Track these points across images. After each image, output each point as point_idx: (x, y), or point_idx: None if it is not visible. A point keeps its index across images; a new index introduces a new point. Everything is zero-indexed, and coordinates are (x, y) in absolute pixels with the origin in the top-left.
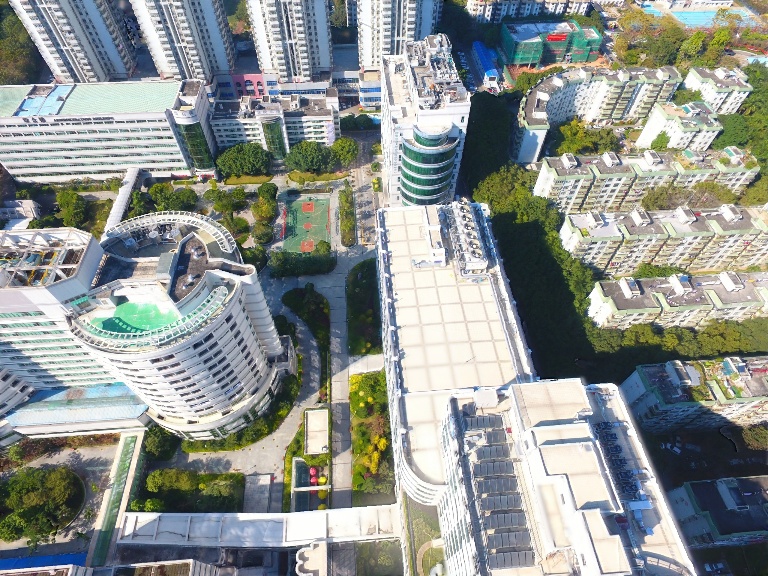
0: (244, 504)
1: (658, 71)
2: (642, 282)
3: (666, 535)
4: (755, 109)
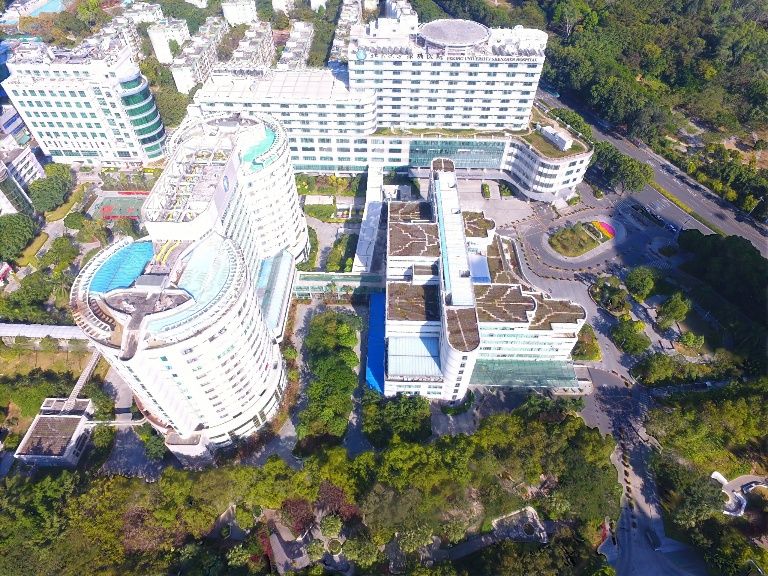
0: None
1: (117, 20)
2: None
3: None
4: (172, 14)
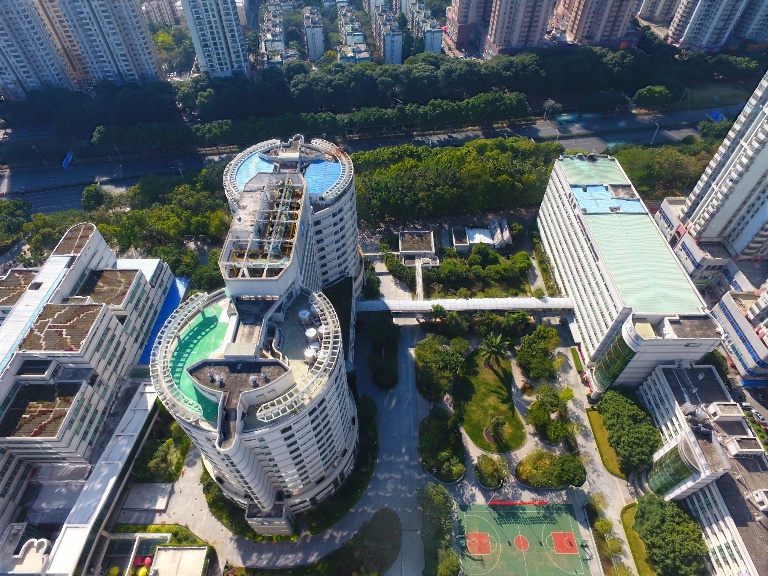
0: (147, 484)
1: None
2: None
3: None
4: None
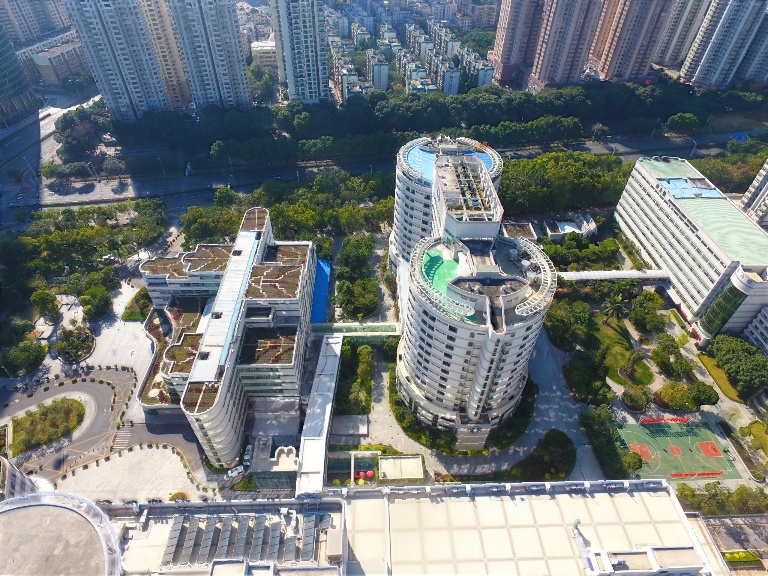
0: (345, 416)
1: None
2: None
3: None
4: None
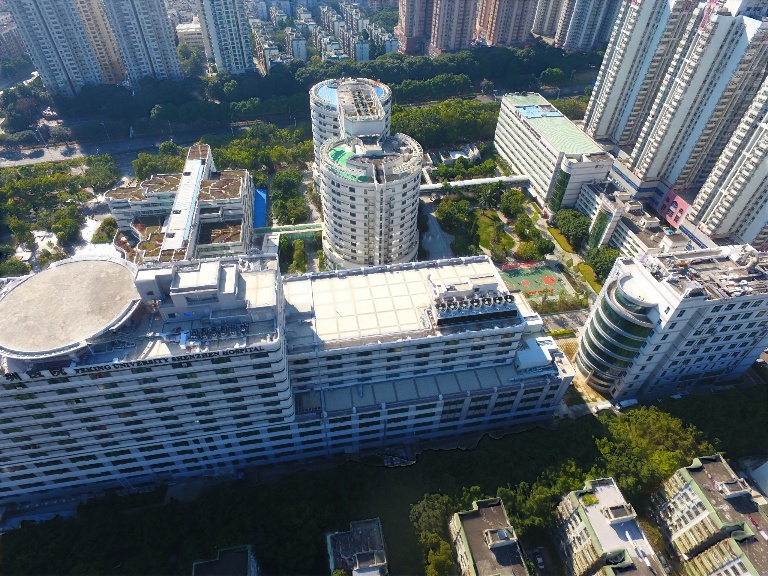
0: None
1: None
2: (521, 567)
3: (162, 356)
4: None
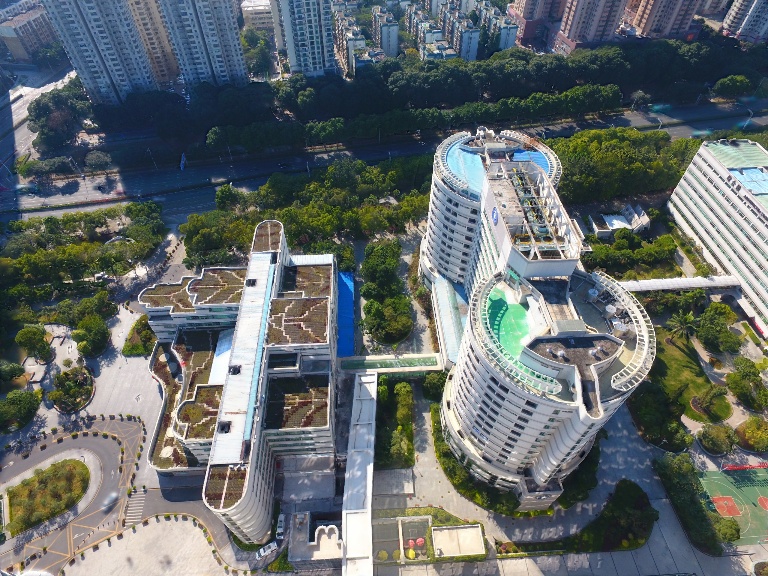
0: (387, 470)
1: None
2: None
3: None
4: None
